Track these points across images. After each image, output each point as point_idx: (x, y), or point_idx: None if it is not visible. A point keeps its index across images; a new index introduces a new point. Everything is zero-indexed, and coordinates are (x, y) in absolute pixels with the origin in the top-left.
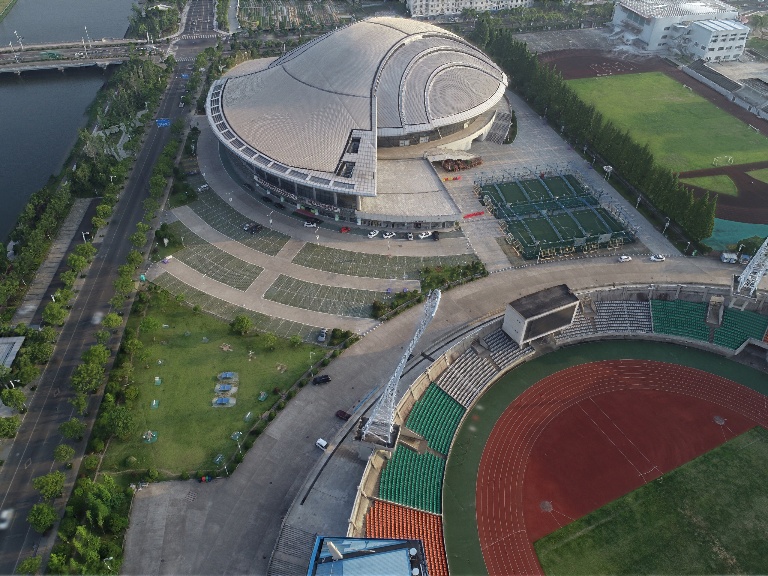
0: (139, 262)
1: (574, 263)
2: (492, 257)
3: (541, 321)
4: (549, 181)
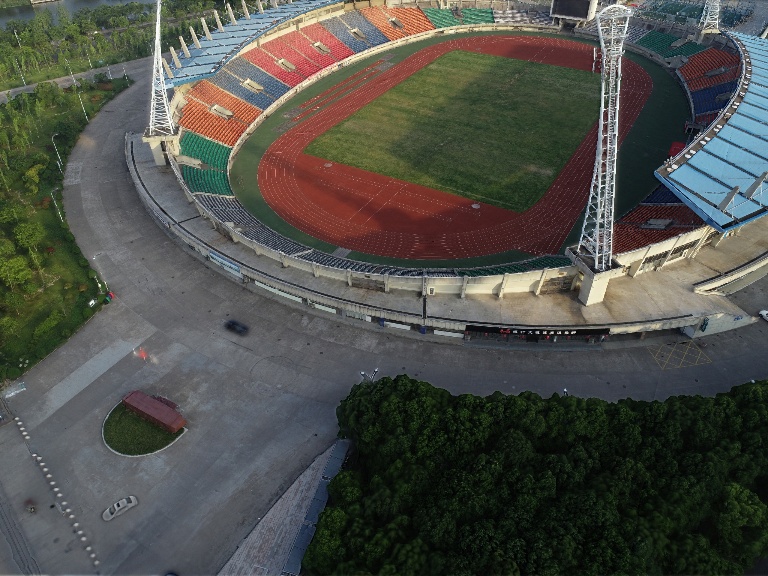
0: None
1: None
2: None
3: (565, 2)
4: (725, 13)
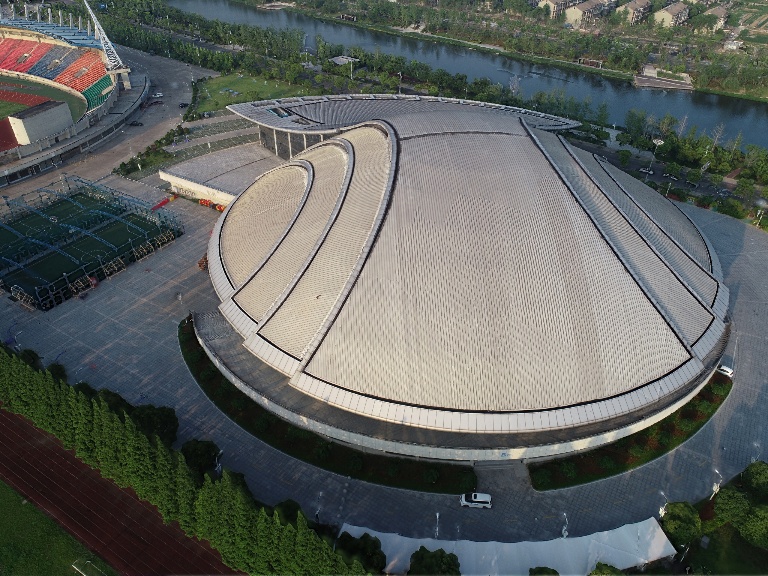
0: None
1: None
2: (116, 184)
3: None
4: None
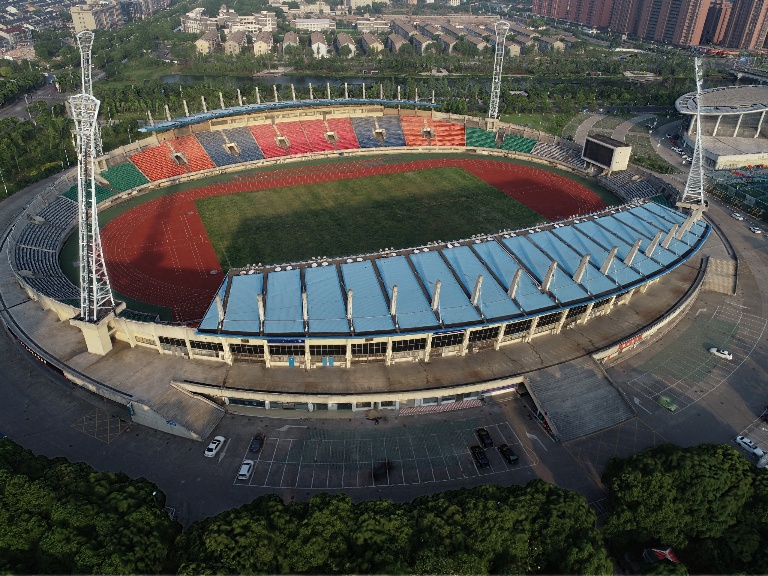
0: (593, 107)
1: (710, 200)
2: None
3: (594, 147)
4: None
